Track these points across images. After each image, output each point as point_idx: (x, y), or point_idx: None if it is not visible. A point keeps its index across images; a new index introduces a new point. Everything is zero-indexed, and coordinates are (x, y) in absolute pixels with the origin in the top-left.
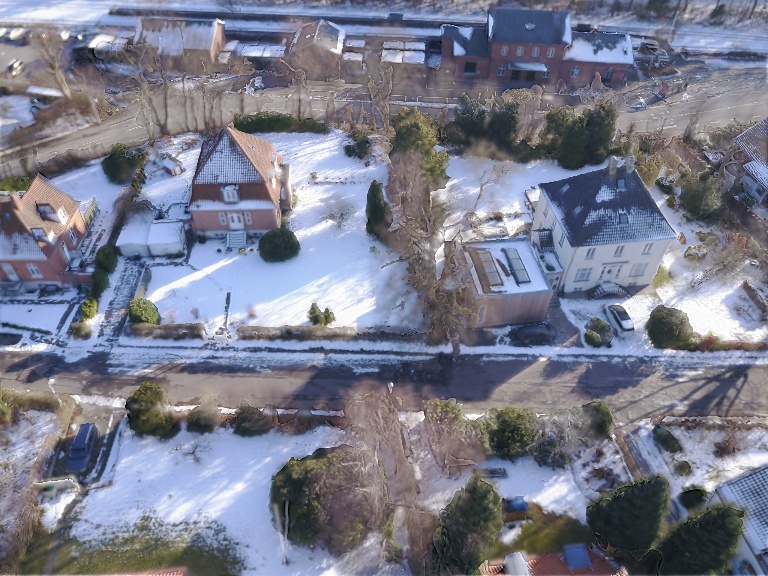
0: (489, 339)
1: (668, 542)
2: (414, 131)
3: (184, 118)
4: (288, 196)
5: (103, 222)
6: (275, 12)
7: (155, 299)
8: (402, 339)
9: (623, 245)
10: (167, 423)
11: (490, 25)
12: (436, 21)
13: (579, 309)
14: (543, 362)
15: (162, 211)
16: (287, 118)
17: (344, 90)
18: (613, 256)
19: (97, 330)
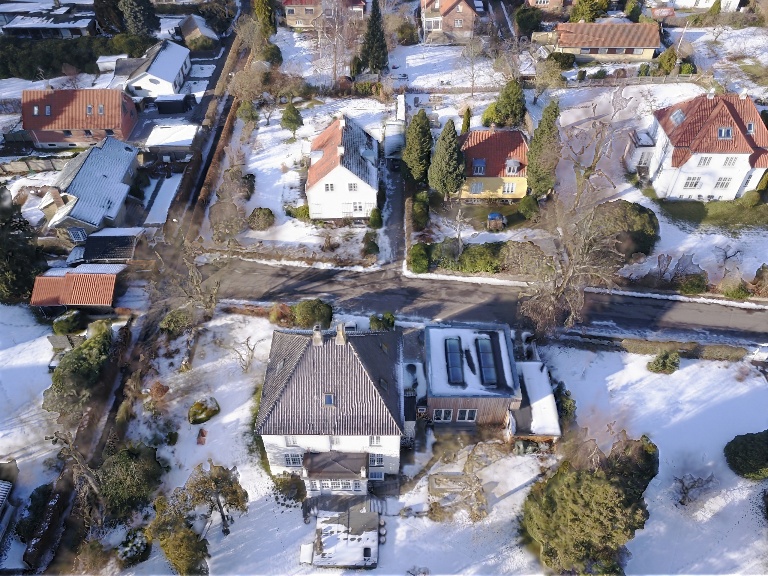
0: None
1: None
2: None
3: None
4: None
5: None
6: None
7: None
8: (574, 341)
9: None
10: (759, 271)
11: None
12: None
13: None
14: (439, 318)
15: None
16: None
17: None
18: None
19: None
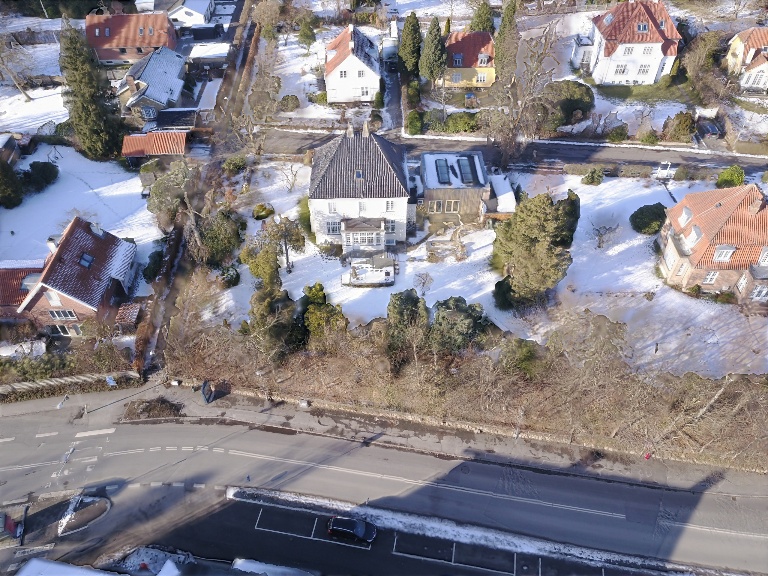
0: None
1: None
2: None
3: None
4: None
5: None
6: None
7: None
8: (529, 169)
9: None
10: (666, 123)
11: None
12: None
13: None
14: None
15: None
16: (733, 376)
17: None
18: None
19: (762, 186)
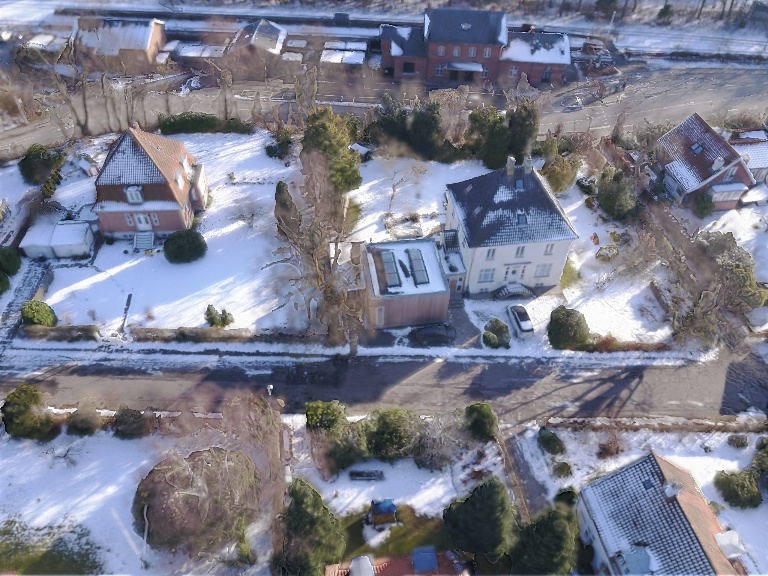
0: (388, 340)
1: (512, 545)
2: (321, 131)
3: (106, 118)
4: (200, 197)
5: (13, 223)
6: (223, 12)
7: (54, 301)
8: (299, 341)
9: (523, 246)
10: (42, 426)
11: (426, 25)
12: (383, 21)
13: (483, 310)
14: (439, 363)
15: (71, 212)
16: (211, 118)
17: (281, 90)
18: (515, 257)
19: None
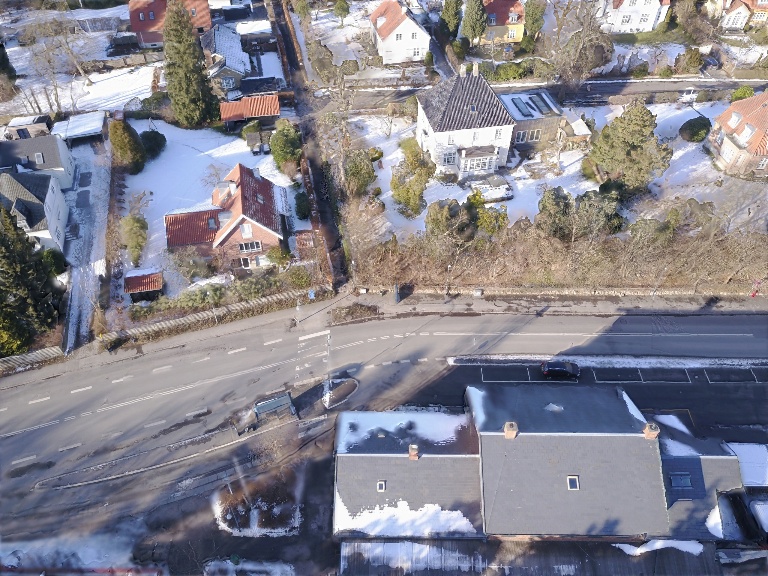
0: None
1: None
2: None
3: None
4: None
5: None
6: None
7: None
8: (580, 104)
9: None
10: (677, 59)
11: (633, 406)
12: None
13: None
14: None
15: None
16: None
17: None
18: None
19: None
